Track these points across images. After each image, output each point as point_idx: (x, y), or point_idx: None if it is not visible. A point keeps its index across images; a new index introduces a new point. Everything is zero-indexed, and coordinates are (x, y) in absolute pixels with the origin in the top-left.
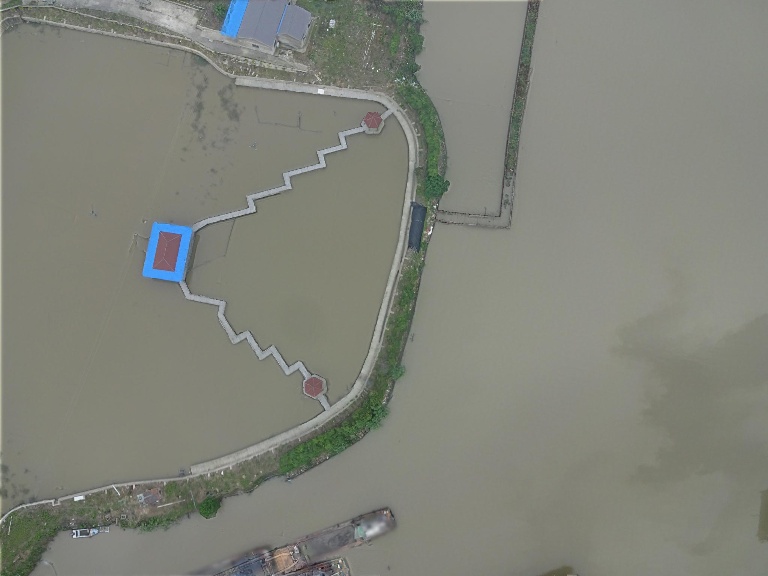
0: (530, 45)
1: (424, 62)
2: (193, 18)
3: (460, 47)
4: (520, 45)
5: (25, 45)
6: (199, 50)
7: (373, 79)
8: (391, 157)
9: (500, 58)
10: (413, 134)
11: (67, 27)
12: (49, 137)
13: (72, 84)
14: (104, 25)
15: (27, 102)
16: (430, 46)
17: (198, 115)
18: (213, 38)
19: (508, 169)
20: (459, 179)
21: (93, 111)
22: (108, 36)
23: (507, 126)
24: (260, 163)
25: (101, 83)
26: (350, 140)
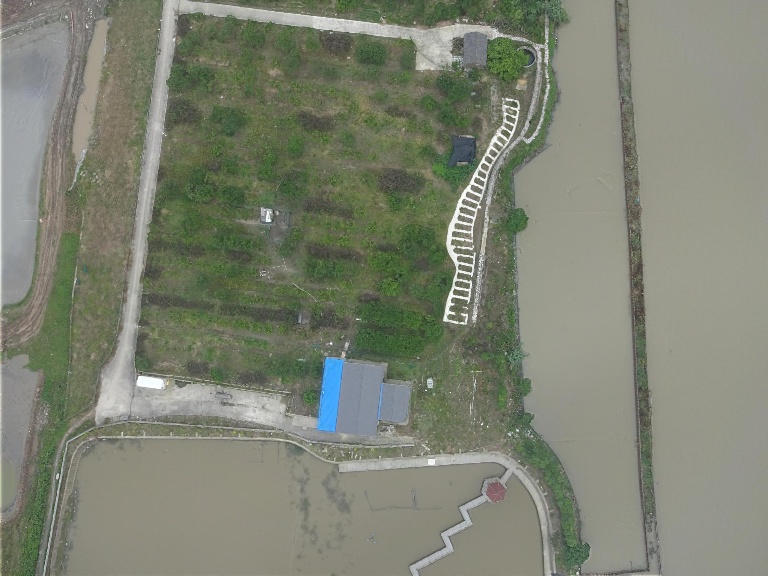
0: (644, 364)
1: (533, 402)
2: (280, 405)
3: (567, 374)
4: (632, 363)
5: (106, 466)
6: (293, 440)
7: (484, 437)
8: (520, 522)
9: (613, 381)
10: (539, 493)
11: (147, 438)
12: (153, 574)
13: (166, 506)
14: (187, 430)
15: (121, 535)
16: (534, 377)
17: (305, 514)
18: (307, 426)
19: (647, 513)
20: (594, 529)
21: (195, 536)
22: (193, 440)
23: (636, 460)
24: (382, 557)
25: (197, 499)
26: (473, 512)
